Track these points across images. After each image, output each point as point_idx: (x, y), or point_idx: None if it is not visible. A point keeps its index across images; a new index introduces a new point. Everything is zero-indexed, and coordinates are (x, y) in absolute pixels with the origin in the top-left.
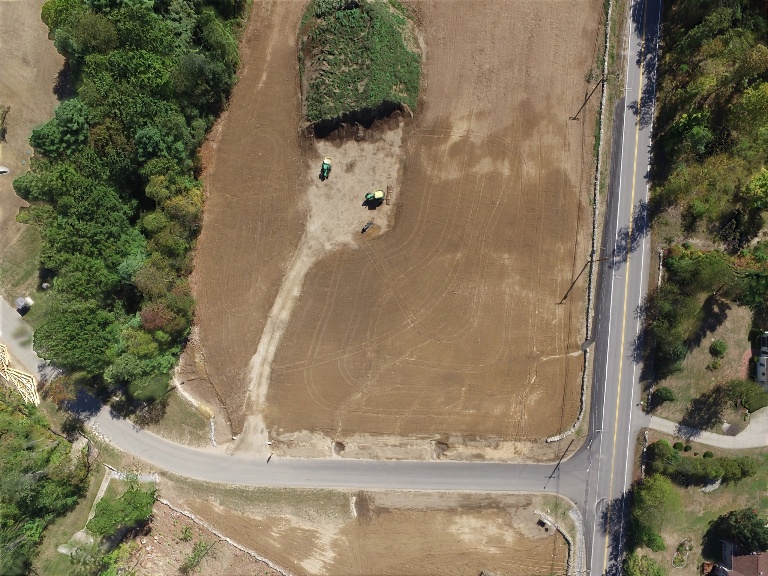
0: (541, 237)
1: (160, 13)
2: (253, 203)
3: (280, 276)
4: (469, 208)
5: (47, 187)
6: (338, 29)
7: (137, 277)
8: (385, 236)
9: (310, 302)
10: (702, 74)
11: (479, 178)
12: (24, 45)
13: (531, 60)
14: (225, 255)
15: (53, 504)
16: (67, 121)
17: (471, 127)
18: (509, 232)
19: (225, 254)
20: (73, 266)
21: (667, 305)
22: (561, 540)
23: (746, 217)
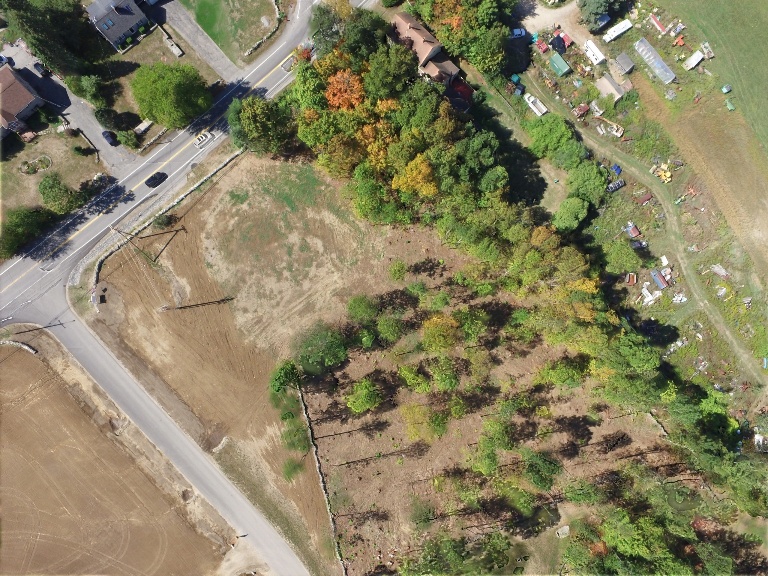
0: None
1: None
2: None
3: None
4: None
5: None
6: None
7: None
8: None
9: None
10: None
11: None
12: None
13: None
14: None
15: None
16: None
17: None
18: None
19: None
20: None
21: None
22: (104, 271)
23: None
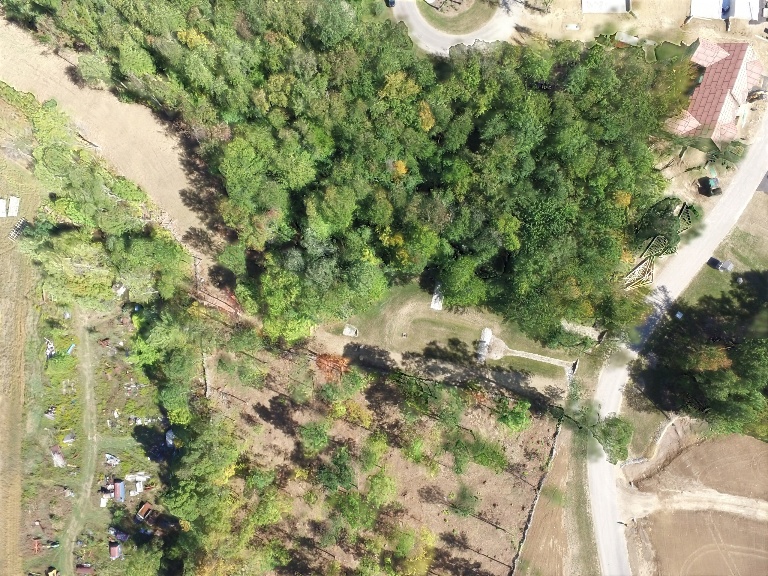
0: None
1: None
2: None
3: None
4: None
5: None
6: None
7: None
8: None
9: None
10: None
11: None
12: None
13: None
14: None
15: (544, 327)
16: None
17: None
18: None
19: None
20: None
21: None
22: None
23: None
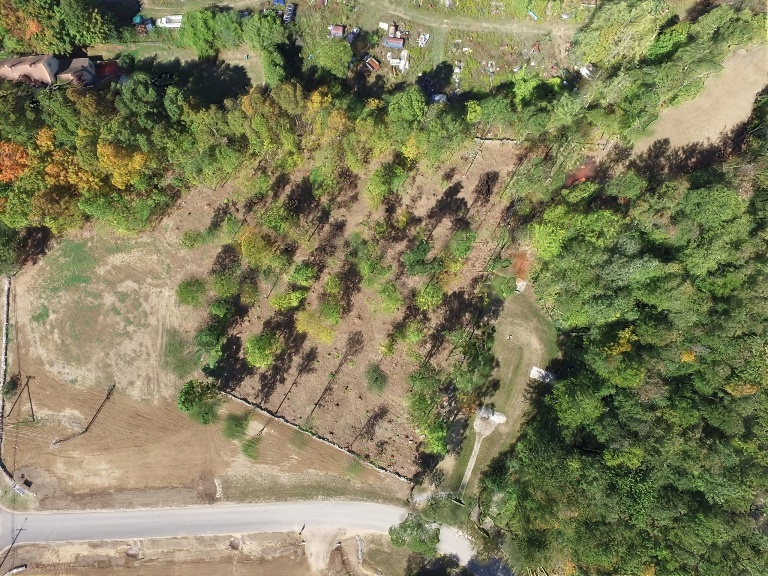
0: None
1: None
2: None
3: None
4: None
5: None
6: None
7: None
8: None
9: None
10: None
11: None
12: None
13: None
14: None
15: None
16: None
17: None
18: None
19: None
20: None
21: None
22: (8, 464)
23: None
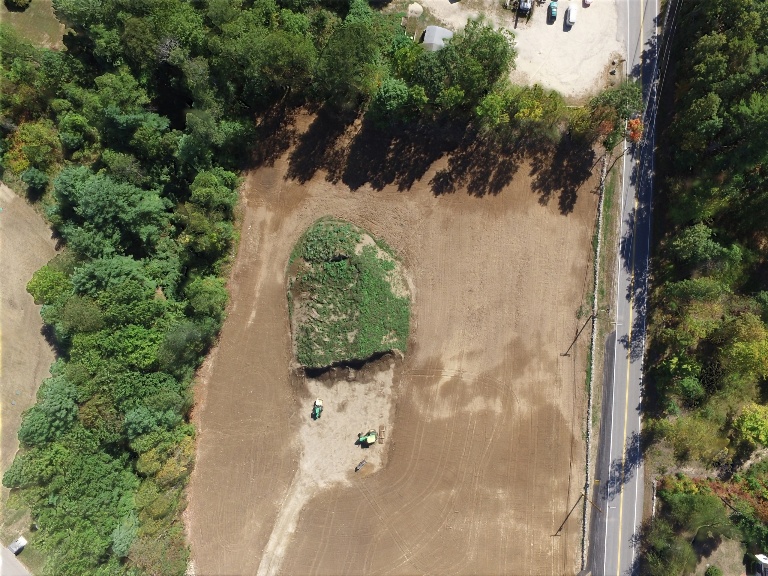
0: (535, 472)
1: (147, 254)
2: (245, 441)
3: (274, 513)
4: (462, 445)
5: (37, 478)
6: (326, 279)
7: (130, 552)
8: (379, 474)
9: (305, 539)
10: (692, 322)
11: (471, 416)
12: (10, 287)
13: (521, 299)
14: (219, 492)
15: None
16: (55, 411)
17: (462, 367)
18: (503, 468)
19: (219, 491)
20: (65, 547)
21: (662, 544)
22: None
23: (738, 441)
